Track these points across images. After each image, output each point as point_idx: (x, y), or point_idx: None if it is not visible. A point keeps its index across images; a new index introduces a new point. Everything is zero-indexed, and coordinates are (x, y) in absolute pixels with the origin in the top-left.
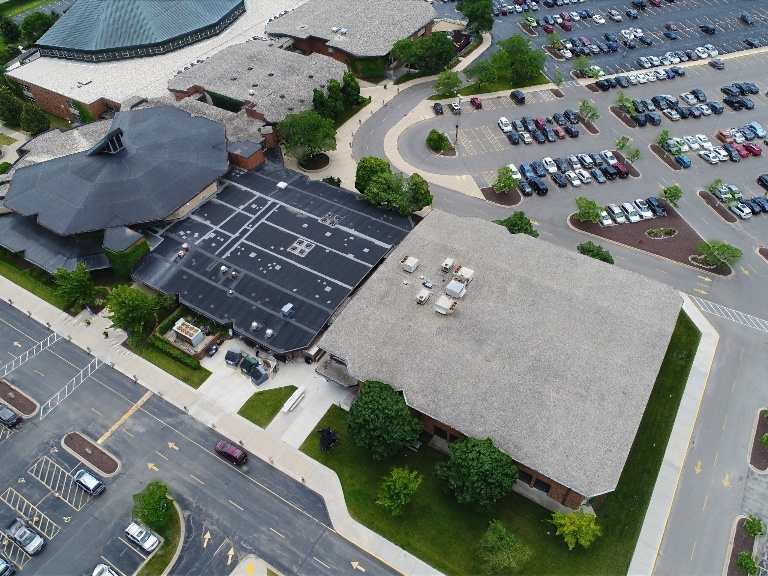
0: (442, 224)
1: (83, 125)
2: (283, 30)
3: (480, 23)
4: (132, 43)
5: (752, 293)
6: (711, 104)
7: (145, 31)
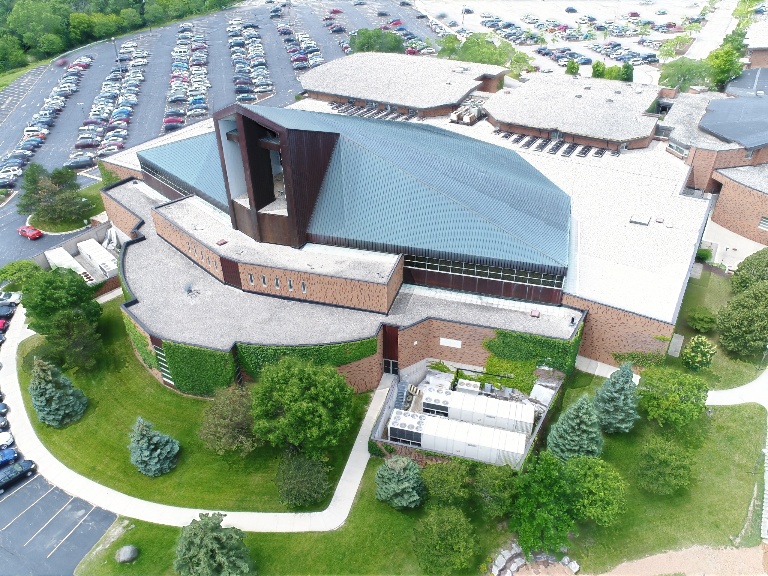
0: (767, 44)
1: (767, 194)
2: (457, 91)
3: (401, 50)
4: (530, 166)
5: (704, 36)
6: (515, 28)
7: (498, 151)
